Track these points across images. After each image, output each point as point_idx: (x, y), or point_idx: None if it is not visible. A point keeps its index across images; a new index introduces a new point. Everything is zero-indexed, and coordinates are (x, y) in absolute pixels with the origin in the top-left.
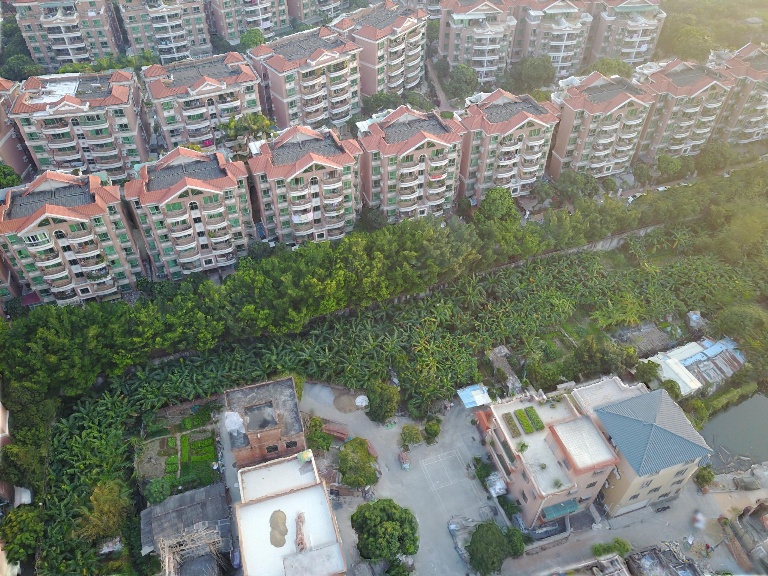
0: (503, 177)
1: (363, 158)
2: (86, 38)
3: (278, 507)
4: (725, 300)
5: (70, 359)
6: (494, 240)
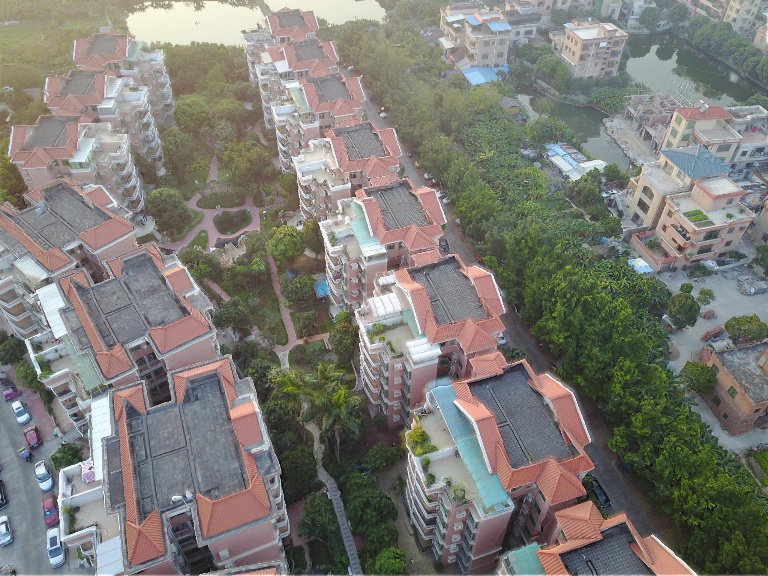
0: None
1: None
2: None
3: None
4: (516, 133)
5: None
6: (497, 212)
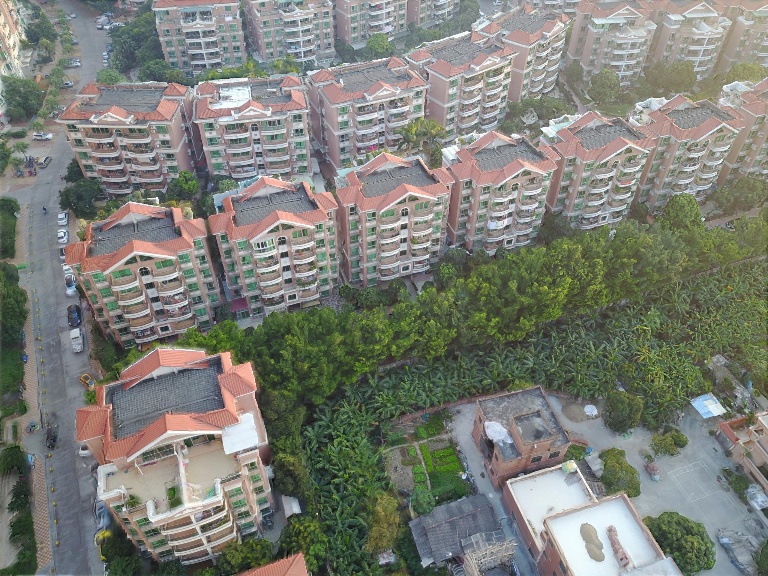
0: (684, 183)
1: (558, 164)
2: (220, 43)
3: (585, 520)
4: None
5: (318, 367)
6: (697, 247)
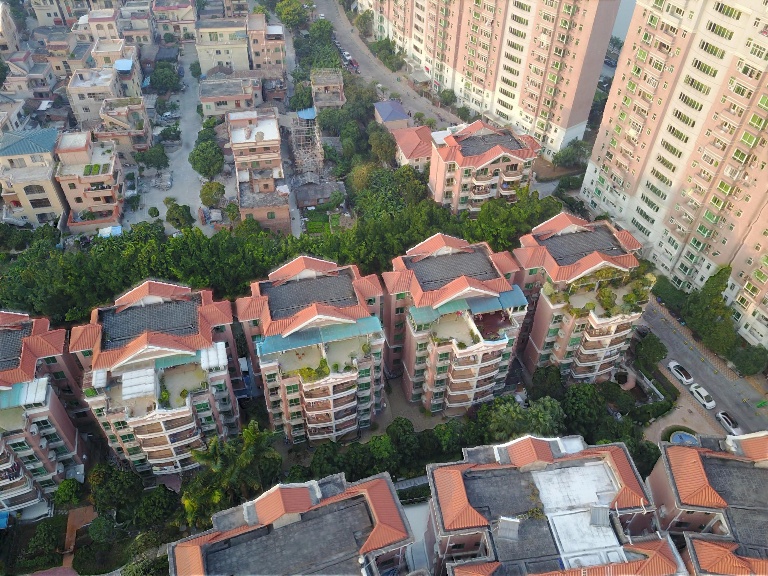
0: None
1: None
2: None
3: None
4: None
5: None
6: None
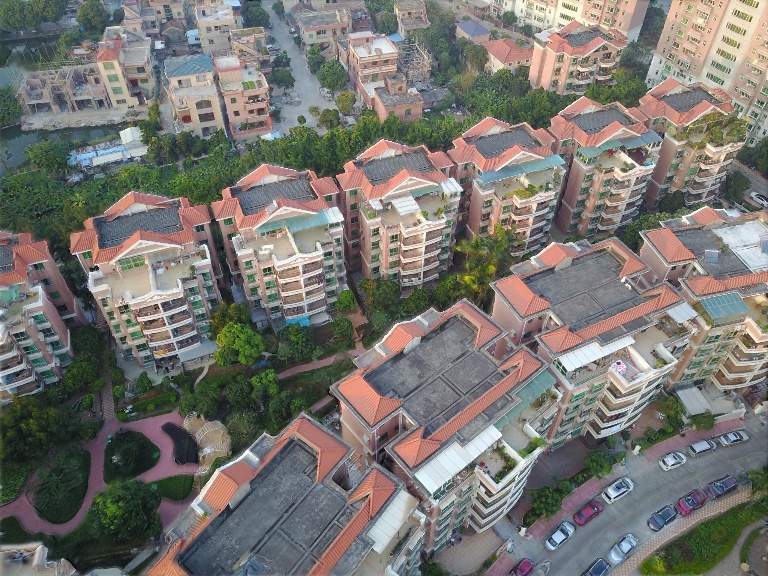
0: None
1: None
2: None
3: None
4: (42, 178)
5: None
6: None
